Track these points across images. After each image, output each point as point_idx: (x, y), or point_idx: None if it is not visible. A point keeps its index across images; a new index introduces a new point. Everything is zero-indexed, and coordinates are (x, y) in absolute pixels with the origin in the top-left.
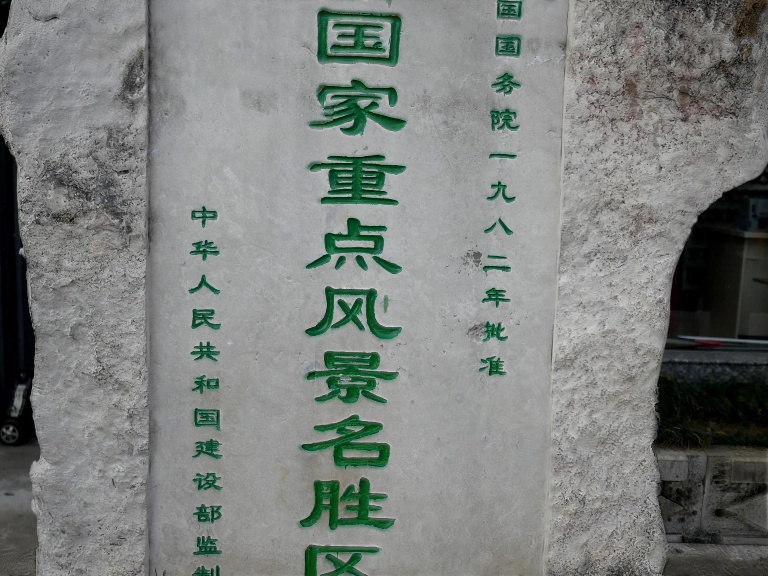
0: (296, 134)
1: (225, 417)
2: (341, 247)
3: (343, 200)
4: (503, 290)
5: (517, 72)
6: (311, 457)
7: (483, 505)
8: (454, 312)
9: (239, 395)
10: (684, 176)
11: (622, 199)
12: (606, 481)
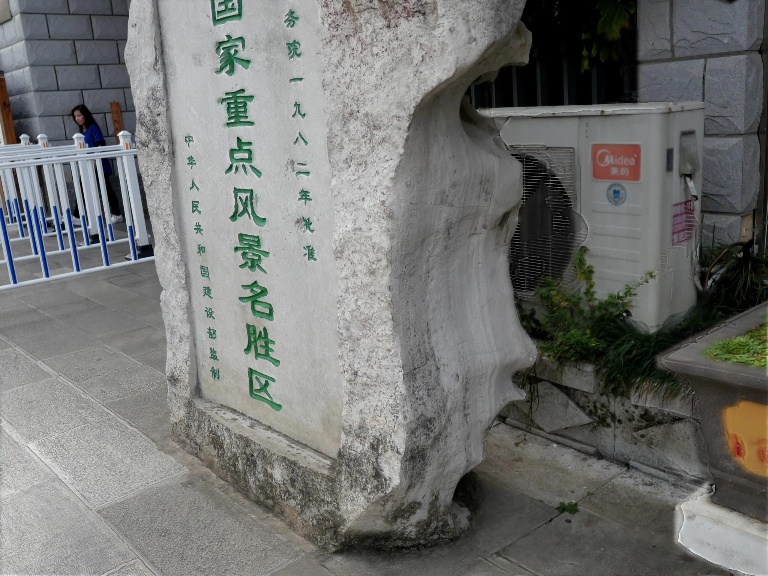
0: (211, 79)
1: (210, 273)
2: (237, 158)
3: (232, 124)
4: (308, 191)
5: (296, 7)
6: (243, 307)
7: (316, 363)
8: (287, 208)
9: (213, 259)
10: (391, 82)
11: (357, 109)
12: (367, 362)
